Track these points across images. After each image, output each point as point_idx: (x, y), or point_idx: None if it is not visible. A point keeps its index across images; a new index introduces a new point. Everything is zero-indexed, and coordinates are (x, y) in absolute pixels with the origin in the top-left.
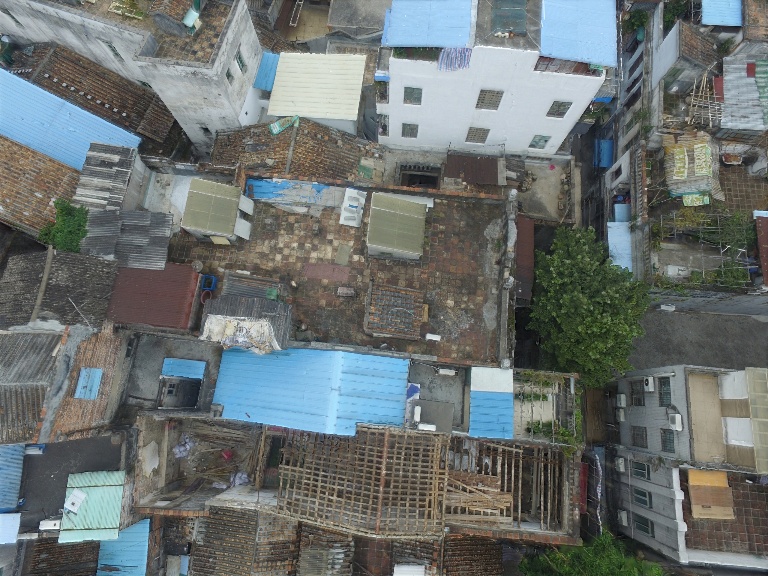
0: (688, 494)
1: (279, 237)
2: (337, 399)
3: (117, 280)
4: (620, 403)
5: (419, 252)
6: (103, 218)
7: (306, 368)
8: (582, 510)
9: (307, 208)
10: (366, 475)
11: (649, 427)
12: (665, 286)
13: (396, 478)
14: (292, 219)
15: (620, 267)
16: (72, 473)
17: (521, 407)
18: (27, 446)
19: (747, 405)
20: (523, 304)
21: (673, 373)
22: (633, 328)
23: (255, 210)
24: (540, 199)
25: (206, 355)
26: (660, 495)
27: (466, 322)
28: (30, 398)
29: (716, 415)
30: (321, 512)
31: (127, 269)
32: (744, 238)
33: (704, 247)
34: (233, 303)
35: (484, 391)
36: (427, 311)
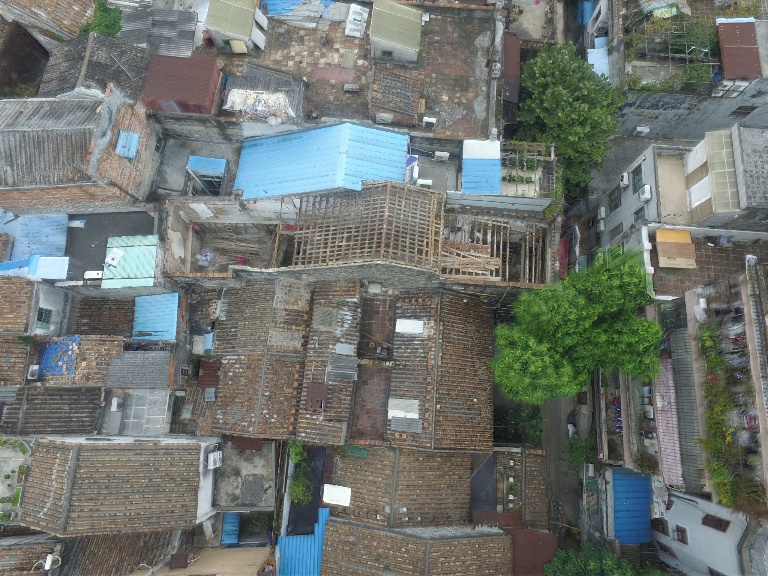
0: (656, 250)
1: (291, 48)
2: (345, 160)
3: (149, 65)
4: (600, 215)
5: (416, 49)
6: (136, 15)
7: (317, 143)
8: (563, 275)
9: (316, 24)
10: (371, 220)
11: (625, 220)
12: (637, 86)
13: (397, 220)
14: (302, 33)
15: (597, 75)
16: (111, 237)
17: (507, 170)
18: (70, 220)
19: (706, 165)
20: (511, 121)
21: (644, 157)
22: (608, 117)
23: (269, 26)
24: (526, 29)
25: (226, 155)
26: (632, 257)
27: (459, 113)
28: (79, 142)
29: (682, 190)
30: (332, 257)
31: (158, 56)
32: (707, 40)
33: (674, 64)
34: (252, 81)
35: (475, 158)
36: (424, 104)
